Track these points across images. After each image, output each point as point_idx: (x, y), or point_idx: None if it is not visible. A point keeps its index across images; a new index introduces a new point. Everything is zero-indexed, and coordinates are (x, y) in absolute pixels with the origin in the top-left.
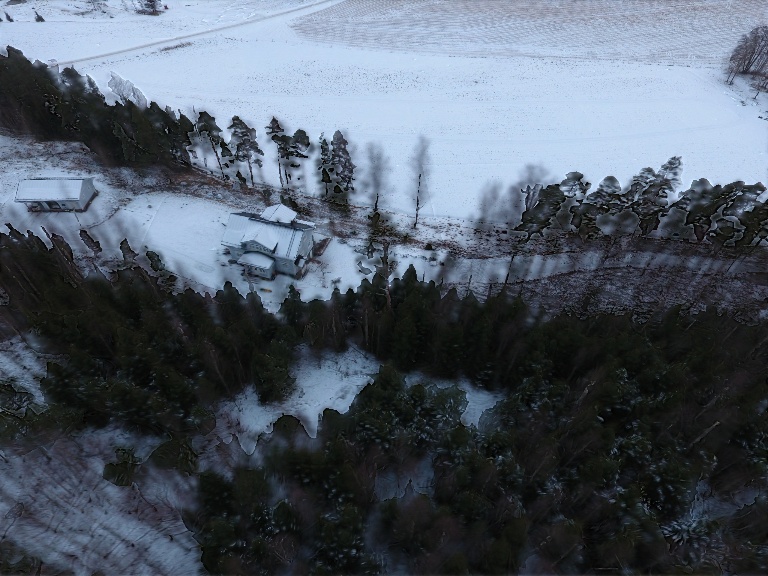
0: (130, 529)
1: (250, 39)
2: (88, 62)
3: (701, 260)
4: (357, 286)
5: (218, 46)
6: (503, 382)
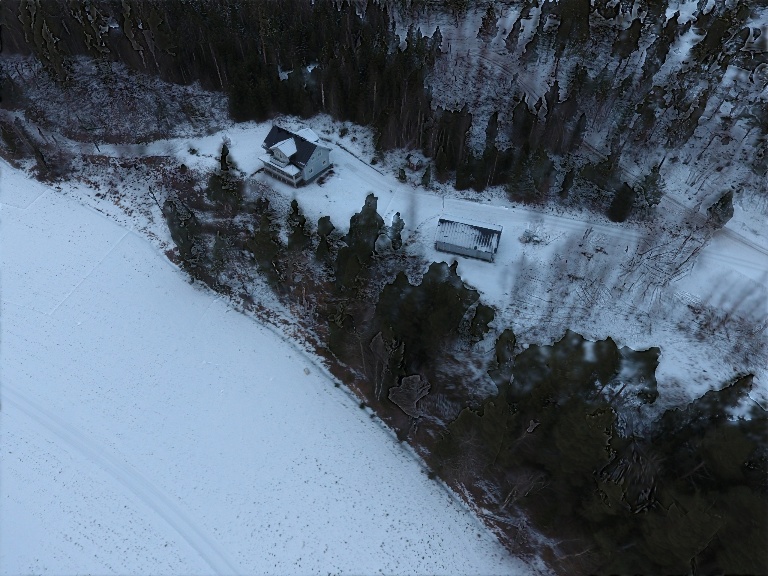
0: None
1: None
2: None
3: None
4: (259, 139)
5: None
6: None
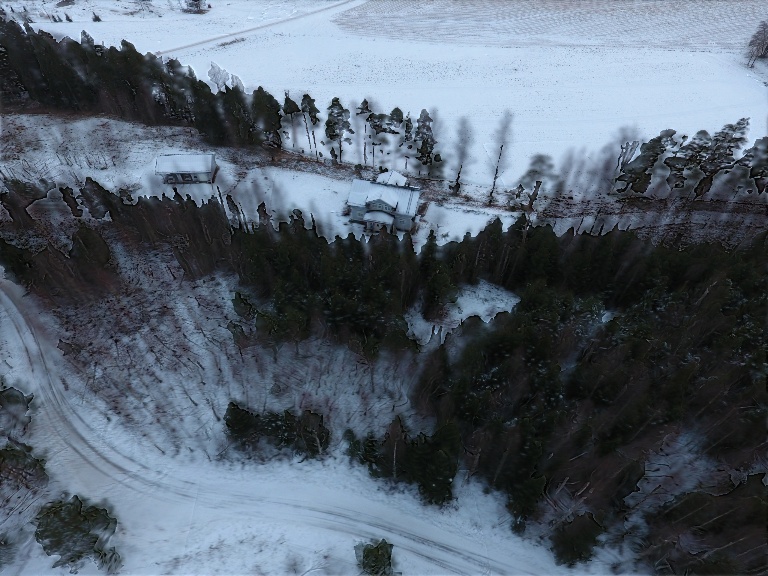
0: (358, 404)
1: (297, 34)
2: None
3: (751, 216)
4: None
5: (269, 41)
6: (617, 302)
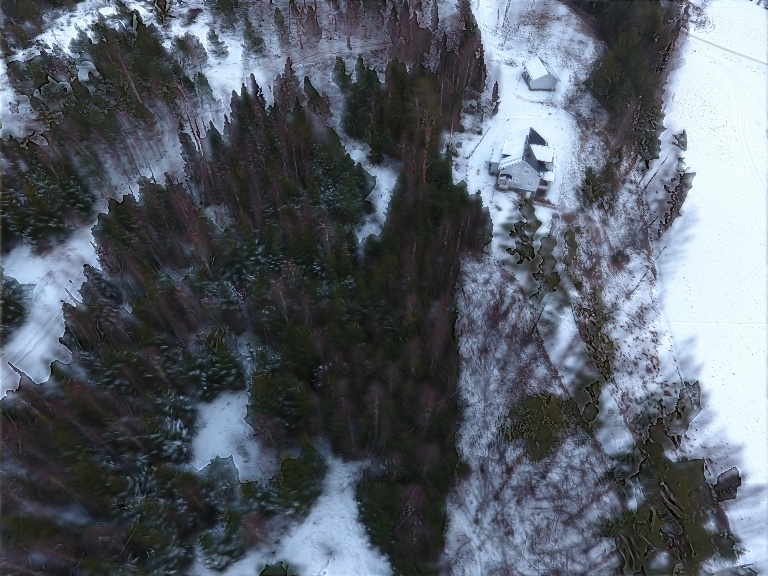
0: None
1: None
2: (761, 65)
3: None
4: (497, 221)
5: None
6: None
